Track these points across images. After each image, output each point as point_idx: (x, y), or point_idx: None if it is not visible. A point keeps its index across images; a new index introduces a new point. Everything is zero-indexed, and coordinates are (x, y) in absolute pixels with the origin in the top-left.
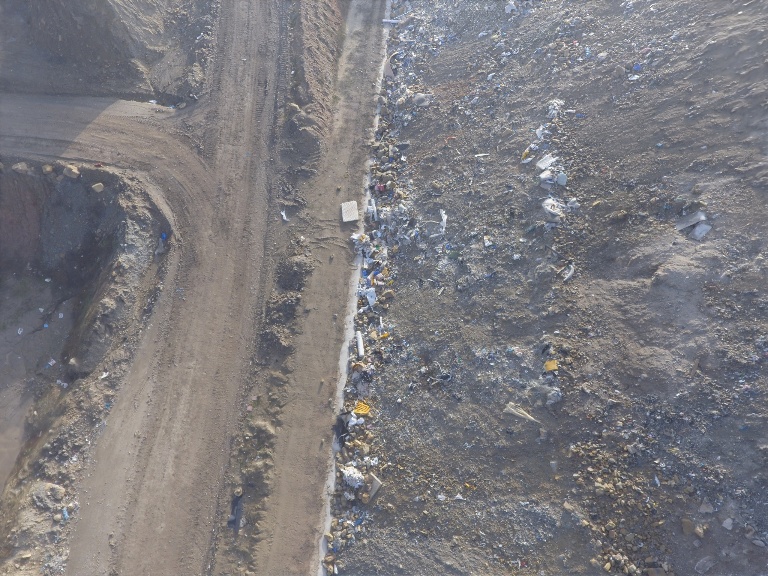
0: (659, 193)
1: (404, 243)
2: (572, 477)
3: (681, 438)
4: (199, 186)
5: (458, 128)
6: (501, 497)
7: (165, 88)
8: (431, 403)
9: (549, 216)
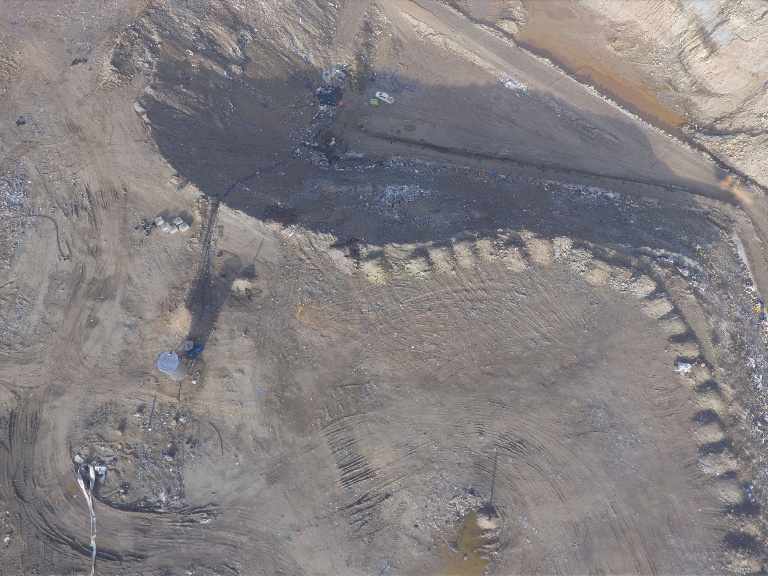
0: None
1: None
2: None
3: None
4: None
5: None
6: None
7: None
8: None
9: None
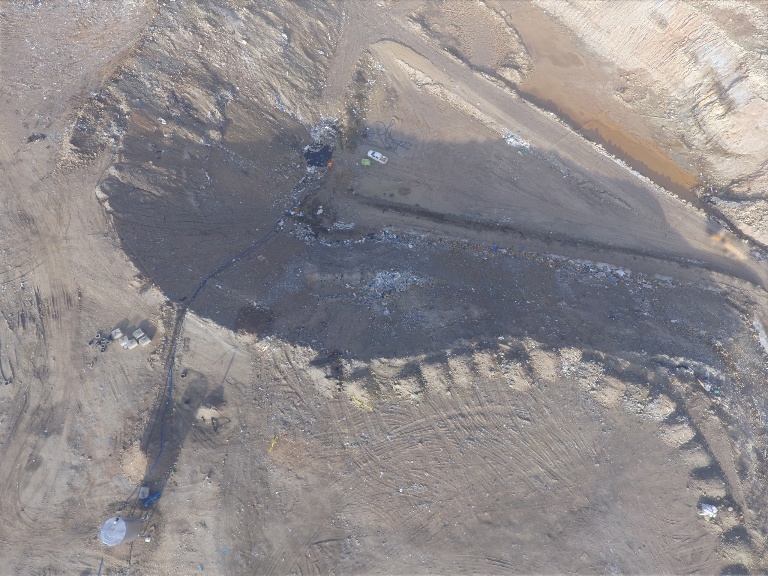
0: None
1: None
2: None
3: None
4: None
5: None
6: None
7: None
8: None
9: None
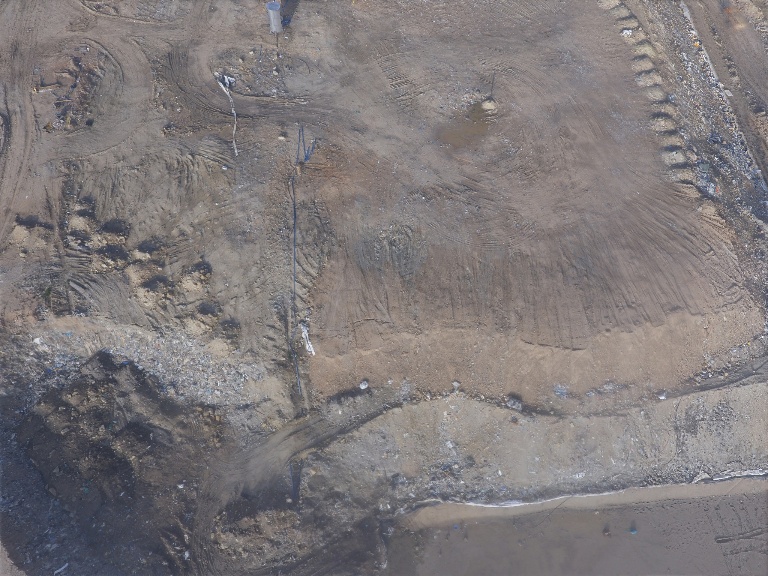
0: None
1: None
2: None
3: None
4: None
5: None
6: None
7: None
8: None
9: None
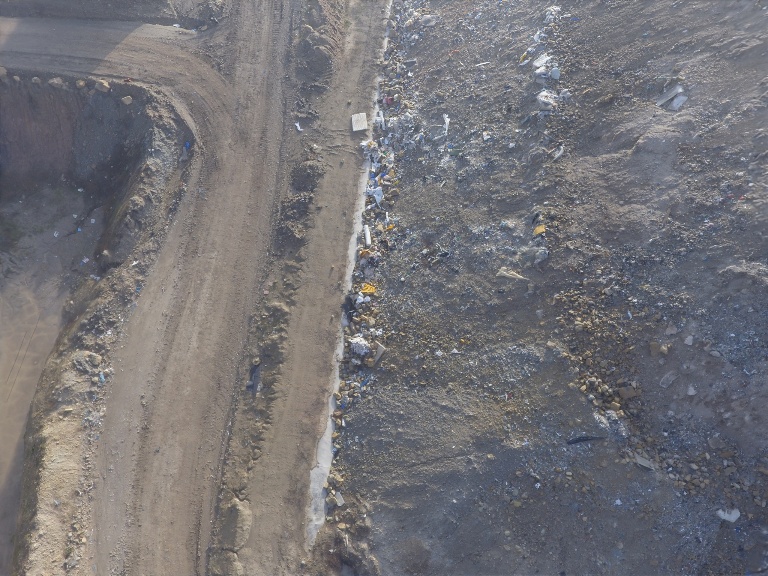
0: (643, 76)
1: (409, 147)
2: (555, 320)
3: (652, 276)
4: (220, 100)
5: (462, 42)
6: (492, 346)
7: (188, 13)
8: (431, 278)
9: (542, 105)
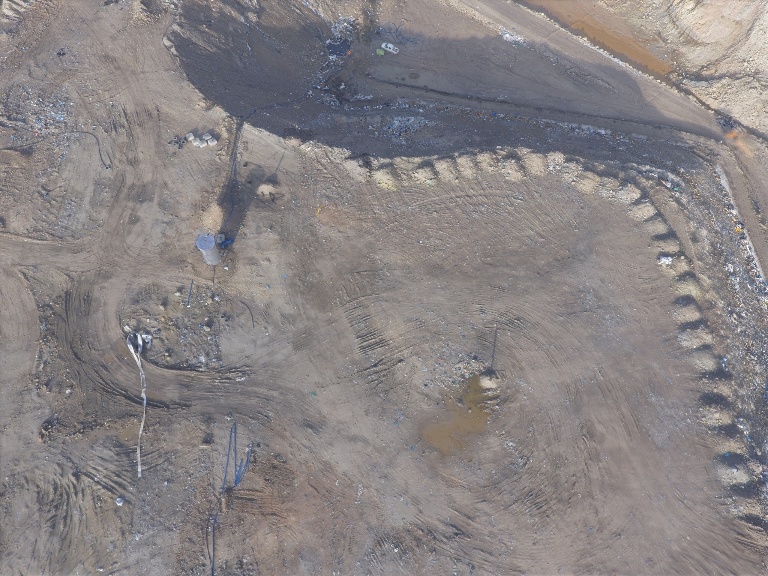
0: None
1: None
2: None
3: None
4: None
5: (762, 329)
6: None
7: None
8: None
9: None
